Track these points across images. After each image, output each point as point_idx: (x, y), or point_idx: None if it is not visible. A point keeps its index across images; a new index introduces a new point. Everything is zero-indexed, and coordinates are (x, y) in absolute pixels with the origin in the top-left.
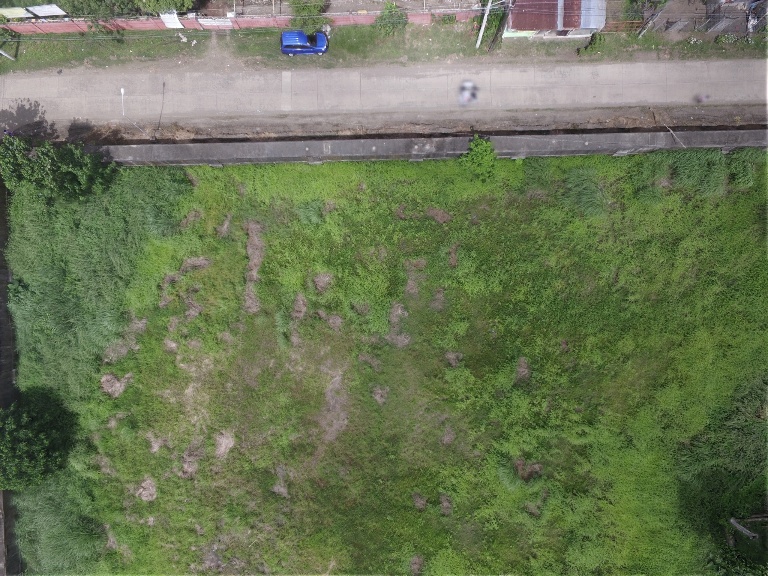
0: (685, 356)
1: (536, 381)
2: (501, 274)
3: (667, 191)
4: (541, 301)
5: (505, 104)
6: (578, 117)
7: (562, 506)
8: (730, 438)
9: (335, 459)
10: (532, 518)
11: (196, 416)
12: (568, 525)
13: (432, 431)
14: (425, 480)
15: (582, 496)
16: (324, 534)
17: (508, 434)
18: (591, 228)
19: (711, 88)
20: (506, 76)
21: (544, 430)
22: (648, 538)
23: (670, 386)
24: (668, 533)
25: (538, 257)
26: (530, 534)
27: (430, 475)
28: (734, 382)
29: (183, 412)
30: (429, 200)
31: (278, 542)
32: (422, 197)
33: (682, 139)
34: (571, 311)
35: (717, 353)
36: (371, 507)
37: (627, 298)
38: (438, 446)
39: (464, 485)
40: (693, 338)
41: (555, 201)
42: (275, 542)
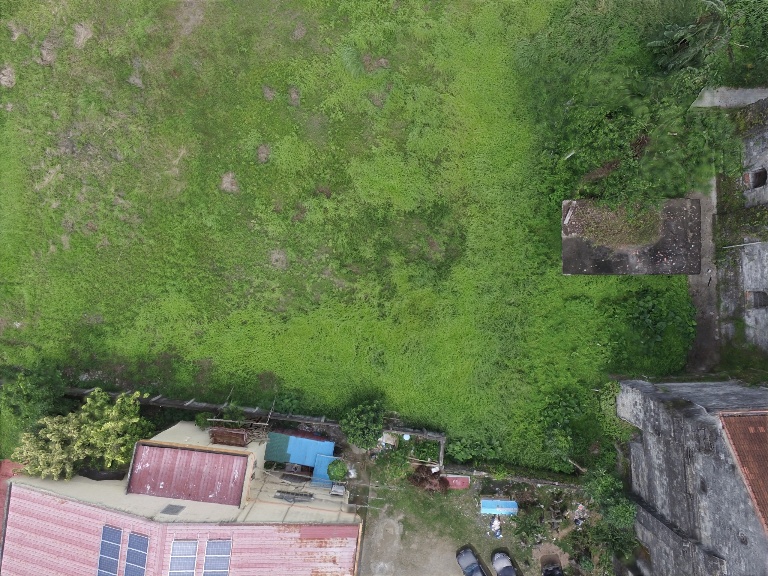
0: None
1: None
2: None
3: None
4: None
5: None
6: None
7: (405, 97)
8: (568, 30)
9: (189, 51)
10: (375, 107)
11: (57, 7)
12: (410, 115)
13: (284, 27)
14: (274, 71)
15: (424, 87)
16: (175, 121)
17: (356, 28)
18: None
19: None
20: None
21: (390, 23)
22: (487, 128)
23: None
24: (505, 122)
25: None
26: (373, 124)
27: (279, 67)
28: None
29: (44, 3)
30: None
31: (130, 127)
32: None
33: None
34: None
35: None
36: (222, 98)
37: None
38: (289, 41)
39: (312, 77)
40: None
41: None
42: (128, 128)
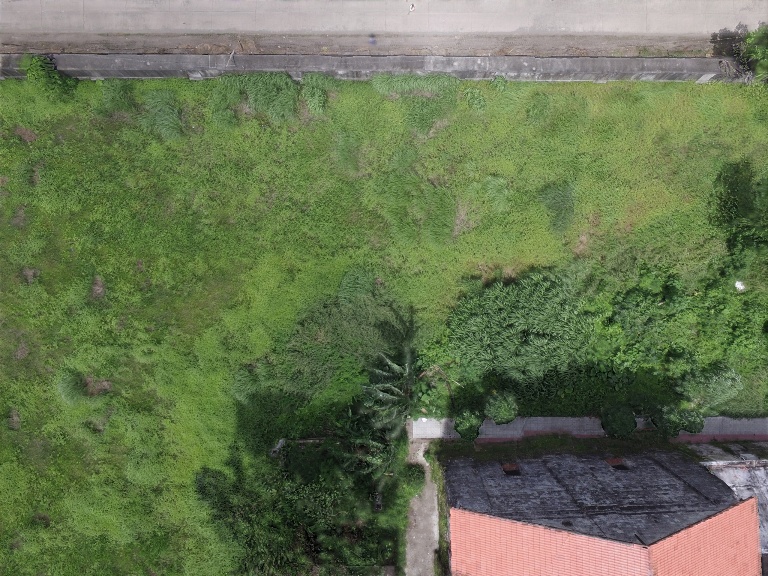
0: (254, 279)
1: (109, 299)
2: (79, 193)
3: (249, 117)
4: (117, 221)
5: (97, 28)
6: (168, 43)
7: (126, 423)
8: (288, 360)
9: None
10: (95, 434)
11: None
12: (130, 442)
13: (7, 346)
14: None
15: (145, 414)
16: None
17: (78, 351)
18: (171, 151)
19: (299, 18)
20: (99, 1)
21: (110, 347)
22: (207, 457)
23: (238, 308)
24: (225, 453)
25: (118, 178)
26: (94, 450)
27: (0, 389)
28: (298, 305)
29: None
30: (13, 118)
31: None
32: (8, 116)
33: (242, 62)
34: (145, 231)
35: (286, 277)
36: None
37: (202, 220)
38: (11, 361)
39: (33, 400)
40: (262, 261)
41: (136, 123)
42: None
